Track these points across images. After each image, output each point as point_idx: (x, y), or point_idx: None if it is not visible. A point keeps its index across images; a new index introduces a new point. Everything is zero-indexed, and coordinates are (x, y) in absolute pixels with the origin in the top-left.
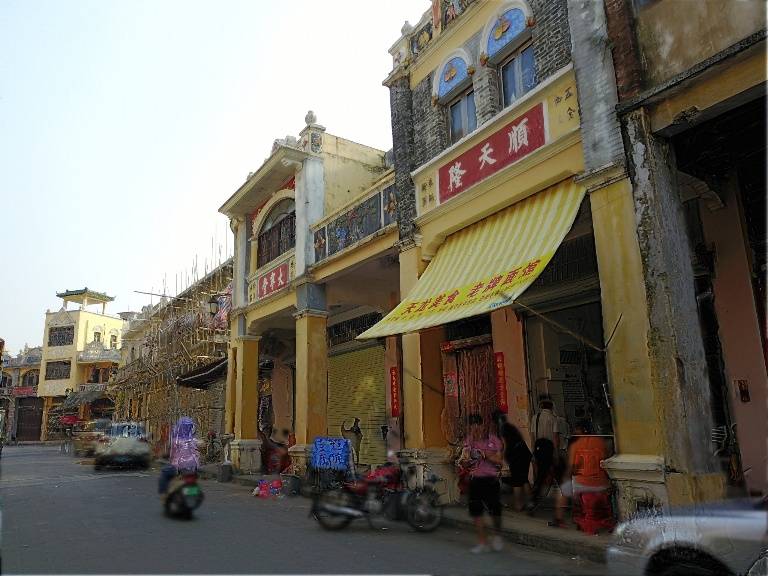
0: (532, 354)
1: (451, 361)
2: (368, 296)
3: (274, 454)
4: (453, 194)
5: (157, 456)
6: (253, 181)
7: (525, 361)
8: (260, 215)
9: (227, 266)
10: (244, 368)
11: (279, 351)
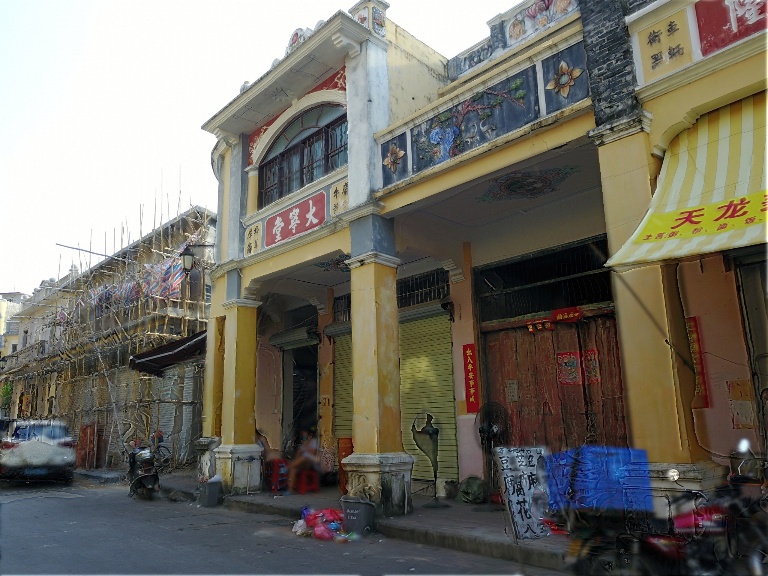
0: (750, 319)
1: (569, 335)
2: (439, 244)
3: (279, 465)
4: (742, 35)
5: (74, 465)
6: (273, 75)
7: (744, 329)
8: (267, 134)
9: (180, 222)
10: (238, 344)
11: (266, 327)
